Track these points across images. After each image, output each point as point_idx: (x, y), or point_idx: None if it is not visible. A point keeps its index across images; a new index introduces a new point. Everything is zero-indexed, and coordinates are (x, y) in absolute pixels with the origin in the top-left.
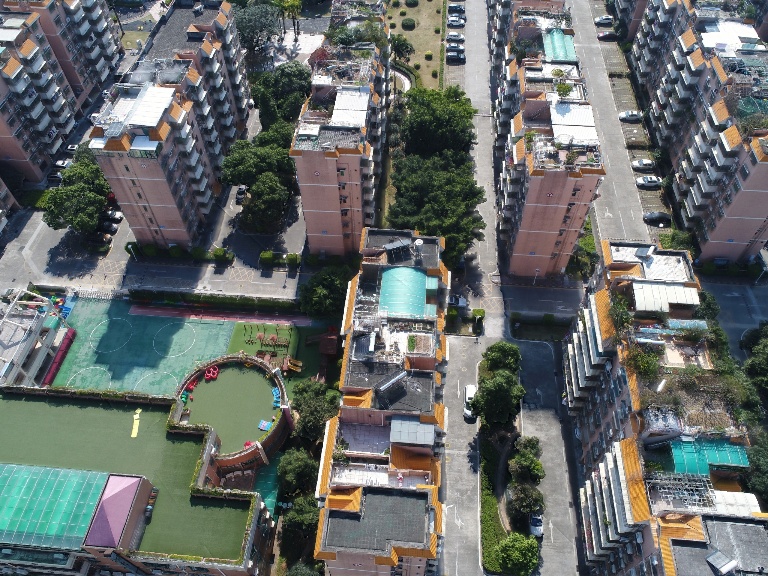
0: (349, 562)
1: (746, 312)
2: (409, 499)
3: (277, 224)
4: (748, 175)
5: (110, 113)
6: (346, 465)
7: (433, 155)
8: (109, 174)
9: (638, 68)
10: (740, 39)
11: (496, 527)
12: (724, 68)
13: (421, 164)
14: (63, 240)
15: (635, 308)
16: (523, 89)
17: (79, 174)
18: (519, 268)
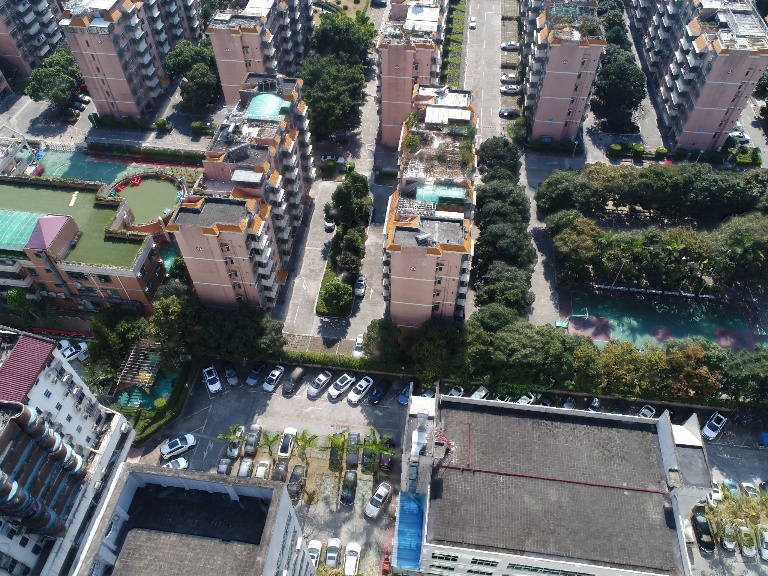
0: (193, 245)
1: None
2: (234, 206)
3: (210, 108)
4: (548, 59)
5: None
6: None
7: None
8: (75, 49)
9: None
10: None
11: None
12: None
13: None
14: (42, 114)
15: None
16: None
17: (57, 61)
18: (389, 139)
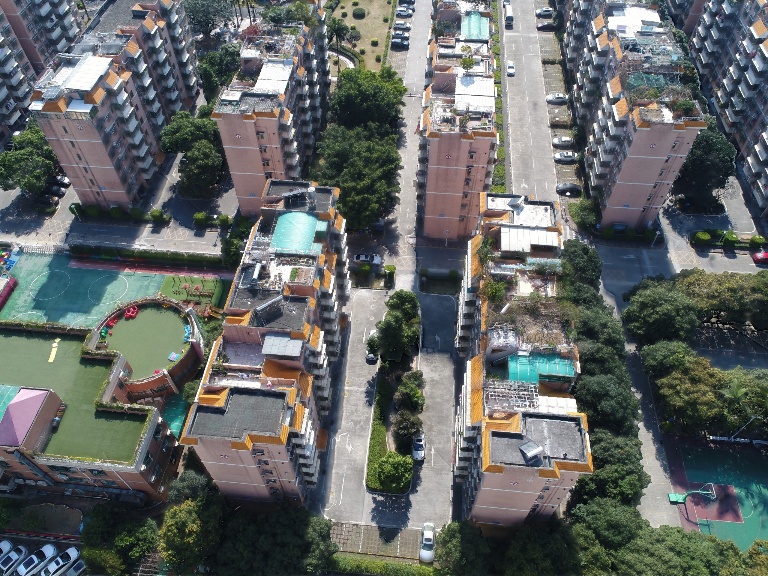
0: (216, 453)
1: (639, 272)
2: (270, 398)
3: (214, 190)
4: (632, 142)
5: (51, 80)
6: (224, 375)
7: (358, 127)
8: (50, 136)
9: (566, 54)
10: (642, 22)
11: (382, 451)
12: (621, 47)
13: (346, 134)
14: (14, 202)
15: (500, 249)
16: (434, 63)
17: (29, 140)
18: (432, 230)
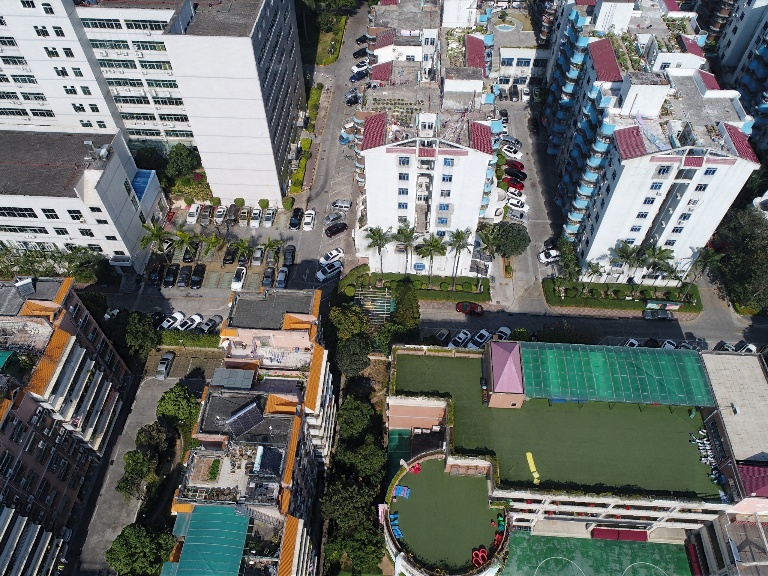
0: None
1: None
2: (245, 326)
3: None
4: None
5: None
6: None
7: None
8: None
9: None
10: None
11: (189, 438)
12: None
13: None
14: None
15: None
16: None
17: None
18: None
